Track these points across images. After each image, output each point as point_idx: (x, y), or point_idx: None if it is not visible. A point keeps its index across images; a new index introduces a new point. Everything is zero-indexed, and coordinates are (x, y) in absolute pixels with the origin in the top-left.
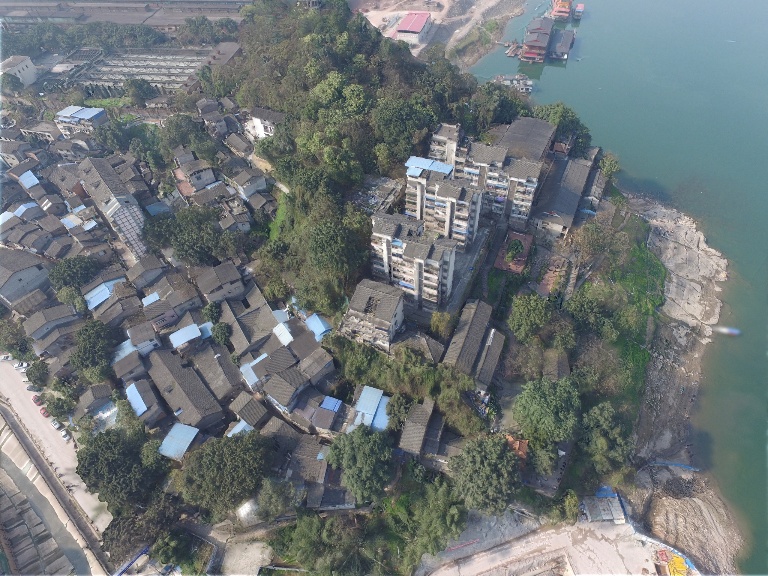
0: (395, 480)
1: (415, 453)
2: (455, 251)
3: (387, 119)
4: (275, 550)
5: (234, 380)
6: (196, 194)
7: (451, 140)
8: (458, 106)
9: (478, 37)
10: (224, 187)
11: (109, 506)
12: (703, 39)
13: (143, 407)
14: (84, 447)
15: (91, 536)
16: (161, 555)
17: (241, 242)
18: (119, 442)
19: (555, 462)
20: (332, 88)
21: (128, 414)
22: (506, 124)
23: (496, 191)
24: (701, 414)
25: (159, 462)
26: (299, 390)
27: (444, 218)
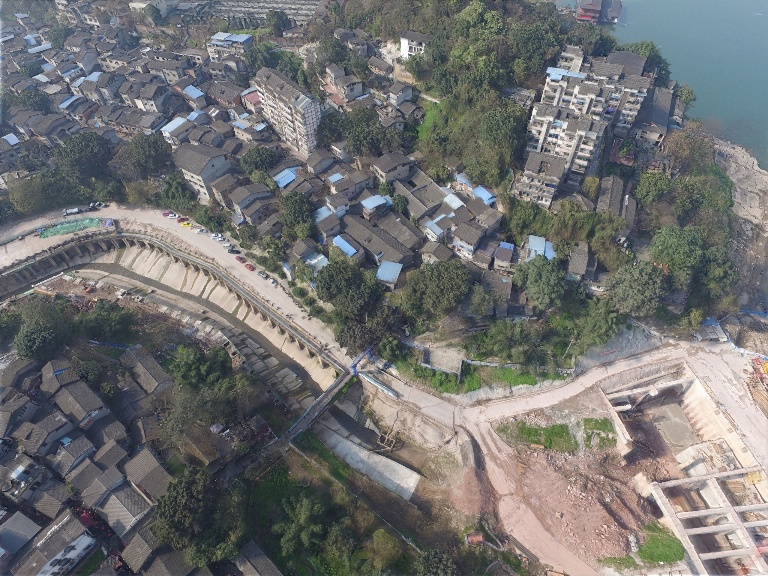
0: None
1: (576, 280)
2: None
3: (527, 37)
4: (472, 349)
5: (418, 235)
6: (350, 103)
7: (579, 56)
8: (568, 37)
9: (535, 1)
10: (373, 99)
11: (338, 318)
12: (734, 11)
13: (353, 250)
14: (296, 287)
15: (316, 347)
16: (389, 348)
17: (401, 138)
18: (347, 268)
19: None
20: (477, 13)
21: (340, 256)
22: (603, 56)
23: (609, 102)
24: None
25: (378, 285)
26: (480, 236)
27: None
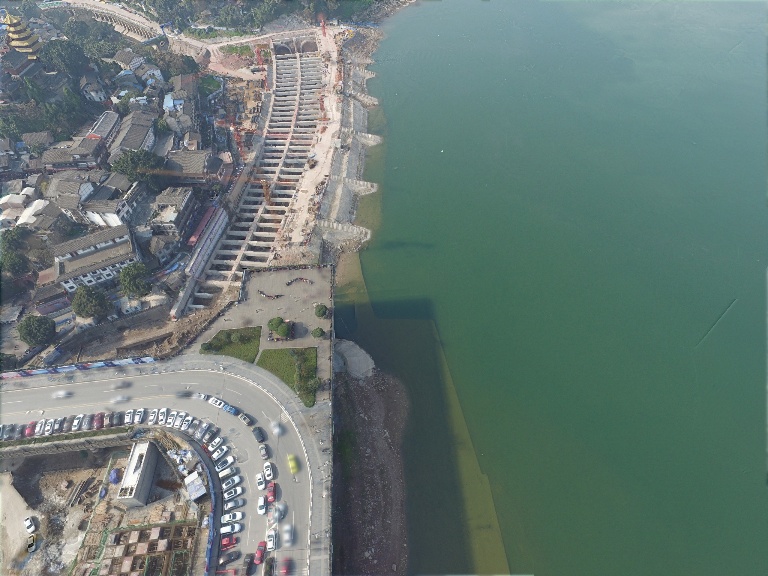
0: (257, 7)
1: None
2: None
3: None
4: (214, 22)
5: None
6: None
7: None
8: None
9: None
10: None
11: (158, 13)
12: None
13: None
14: None
15: None
16: (176, 19)
17: None
18: None
19: None
20: None
21: None
22: None
23: None
24: (390, 19)
25: None
26: None
27: None
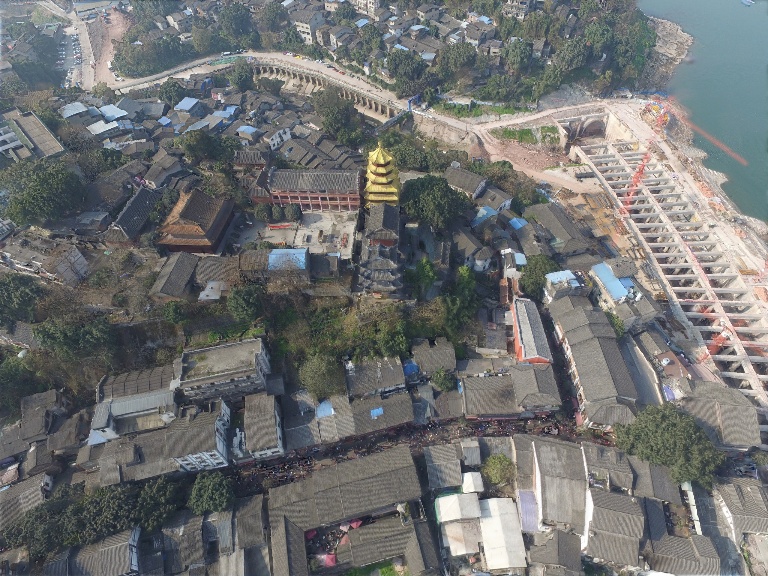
0: (527, 74)
1: (538, 56)
2: None
3: None
4: (477, 94)
5: None
6: None
7: None
8: None
9: None
10: None
11: (400, 81)
12: None
13: (407, 49)
14: None
15: None
16: None
17: None
18: None
19: None
20: None
21: None
22: None
23: None
24: (672, 84)
25: (422, 62)
26: (482, 37)
27: None
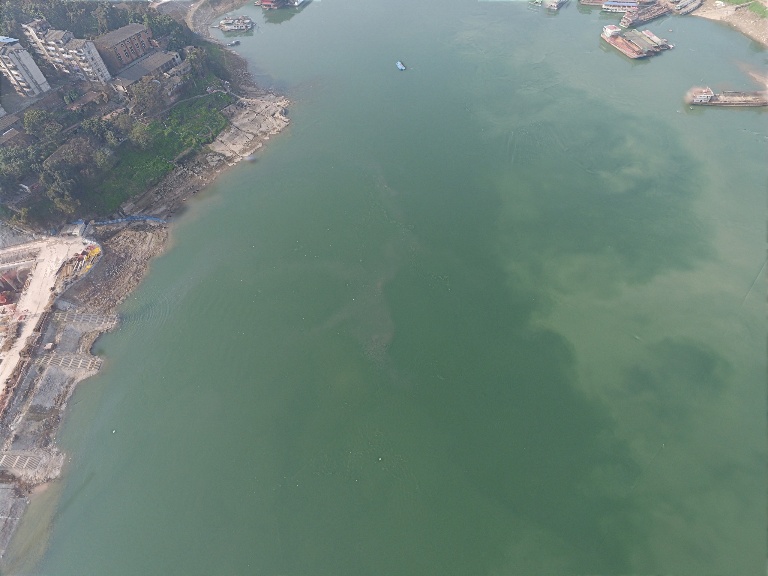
0: None
1: None
2: (30, 97)
3: None
4: None
5: None
6: None
7: (28, 26)
8: (75, 14)
9: None
10: None
11: None
12: None
13: None
14: None
15: None
16: None
17: None
18: None
19: (8, 185)
20: None
21: None
22: None
23: (71, 62)
24: (195, 199)
25: None
26: None
27: (6, 70)
